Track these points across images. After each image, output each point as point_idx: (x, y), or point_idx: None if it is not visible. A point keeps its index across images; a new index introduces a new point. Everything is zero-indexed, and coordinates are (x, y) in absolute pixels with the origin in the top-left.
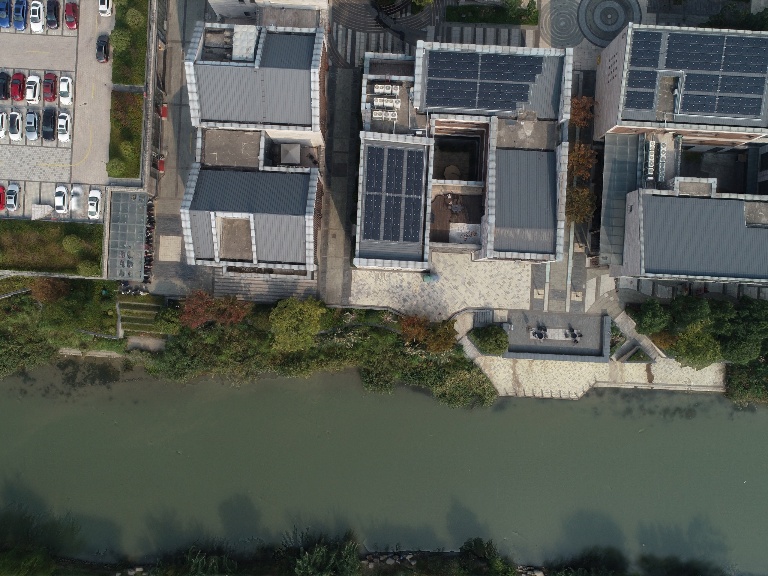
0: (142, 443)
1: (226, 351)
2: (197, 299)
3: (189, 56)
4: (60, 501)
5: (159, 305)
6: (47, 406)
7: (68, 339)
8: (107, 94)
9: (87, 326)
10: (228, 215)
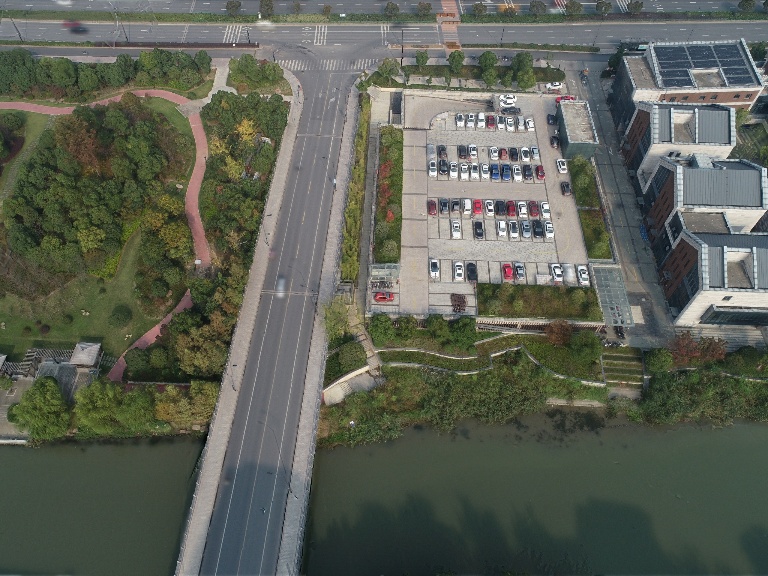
0: (644, 484)
1: (710, 389)
2: (684, 339)
3: (676, 164)
4: (573, 548)
5: (636, 356)
6: (541, 452)
7: (557, 388)
8: (573, 213)
9: (578, 373)
10: (735, 250)
